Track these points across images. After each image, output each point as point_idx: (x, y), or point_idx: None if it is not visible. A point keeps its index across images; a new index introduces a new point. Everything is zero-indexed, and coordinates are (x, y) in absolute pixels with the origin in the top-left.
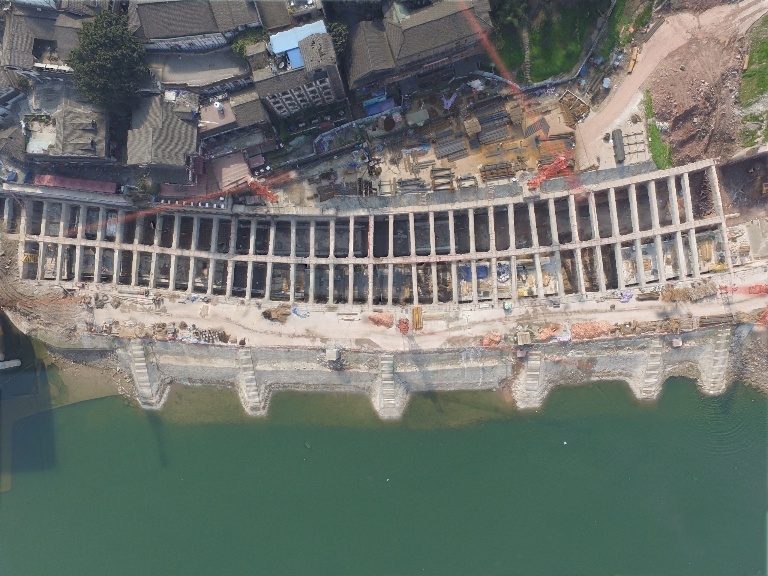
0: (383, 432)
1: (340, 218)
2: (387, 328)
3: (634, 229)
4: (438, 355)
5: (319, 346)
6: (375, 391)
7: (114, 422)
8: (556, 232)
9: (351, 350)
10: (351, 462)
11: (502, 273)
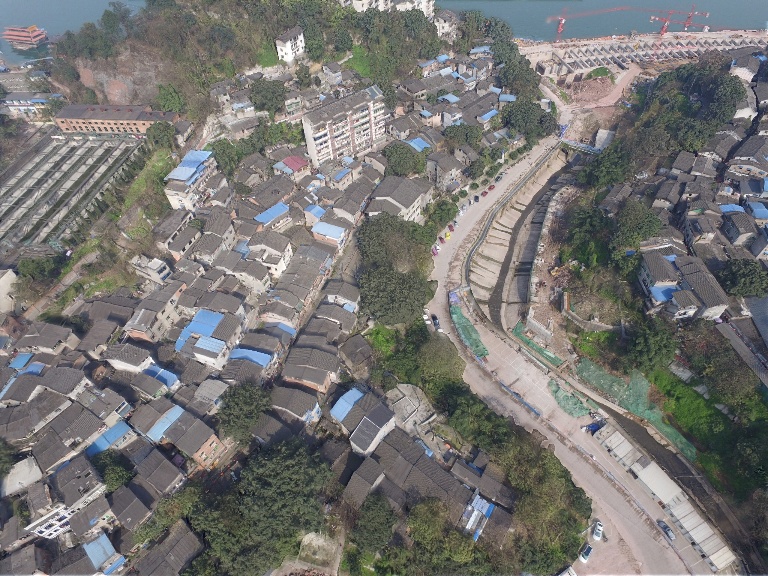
0: None
1: None
2: None
3: None
4: None
5: None
6: None
7: None
8: None
9: None
10: None
11: None
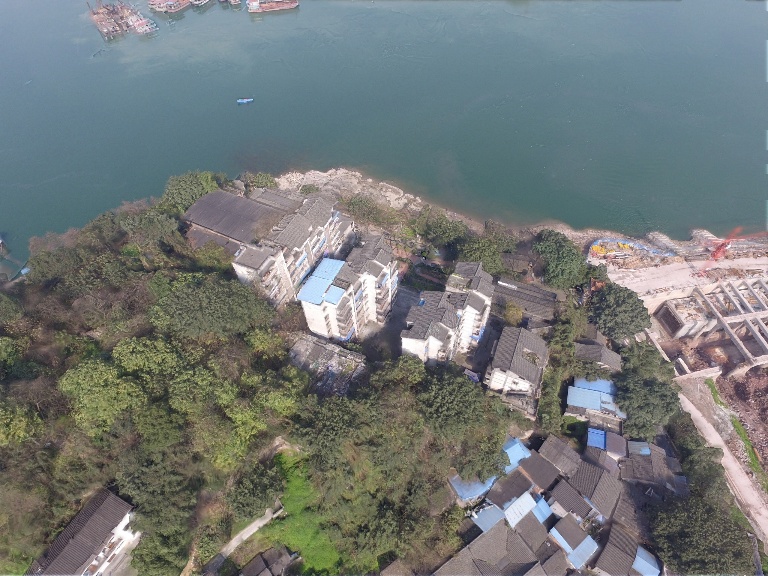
0: None
1: None
2: None
3: None
4: None
5: None
6: None
7: None
8: None
9: None
10: None
11: None
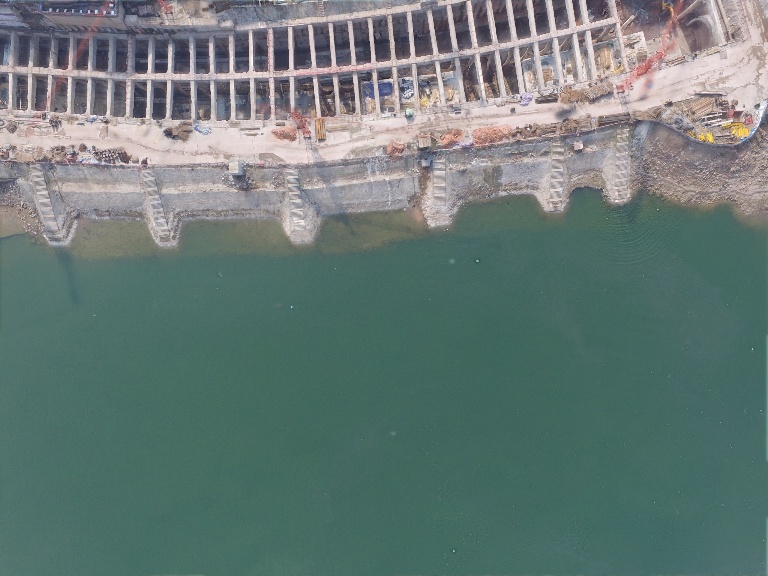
0: (296, 258)
1: (242, 40)
2: (290, 141)
3: (532, 33)
4: (343, 168)
5: (222, 163)
6: (285, 214)
7: (22, 261)
8: (455, 39)
9: (255, 166)
10: (265, 289)
11: (406, 89)
